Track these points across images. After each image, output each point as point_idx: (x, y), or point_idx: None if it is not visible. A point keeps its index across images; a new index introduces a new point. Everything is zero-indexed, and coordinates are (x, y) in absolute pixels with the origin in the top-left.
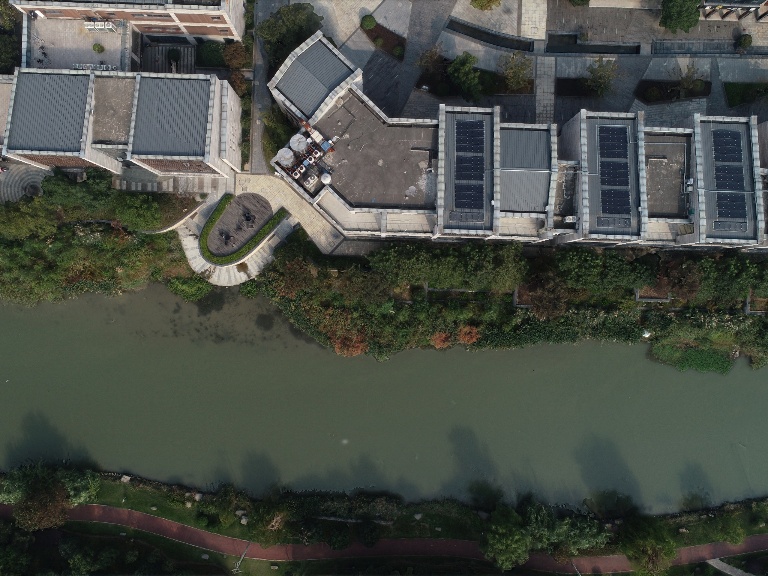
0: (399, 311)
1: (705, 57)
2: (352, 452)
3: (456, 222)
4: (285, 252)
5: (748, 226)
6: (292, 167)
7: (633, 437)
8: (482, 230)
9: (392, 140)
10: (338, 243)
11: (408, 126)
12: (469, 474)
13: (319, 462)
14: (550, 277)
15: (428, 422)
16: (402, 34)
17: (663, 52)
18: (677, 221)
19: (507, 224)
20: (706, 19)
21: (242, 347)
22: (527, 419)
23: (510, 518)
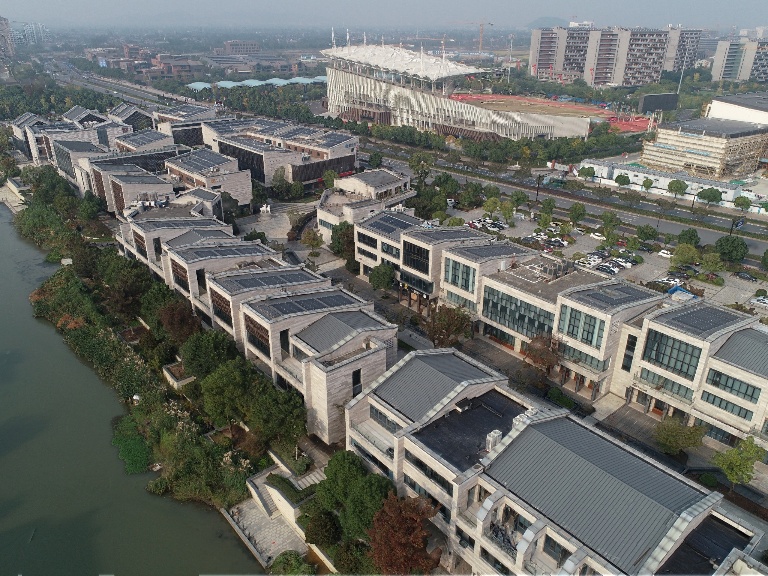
0: None
1: None
2: None
3: None
4: None
5: None
6: None
7: (10, 451)
8: (143, 229)
9: None
10: None
11: None
12: None
13: None
14: None
15: None
16: None
17: None
18: None
19: None
20: (409, 307)
21: (19, 279)
22: (6, 390)
23: None
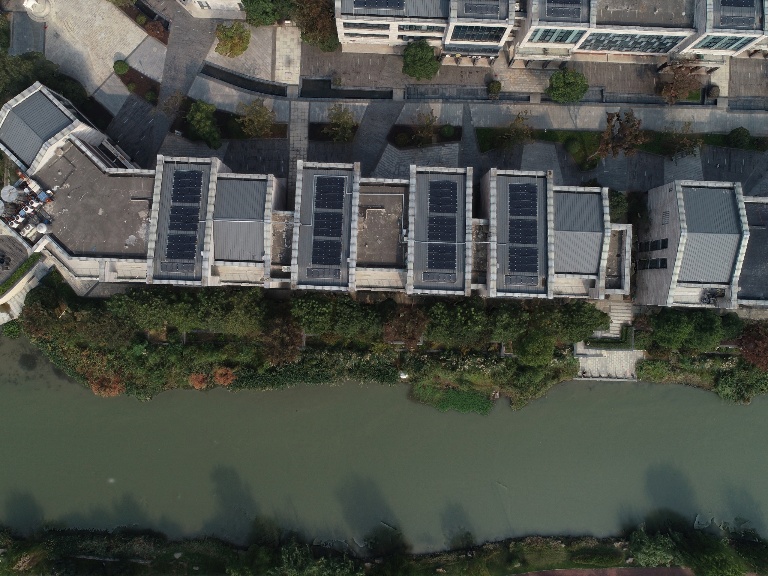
0: (151, 353)
1: (457, 102)
2: (115, 491)
3: (167, 272)
4: (31, 296)
5: (457, 277)
6: (11, 216)
7: (395, 477)
8: (191, 281)
9: (112, 190)
10: (93, 285)
11: (129, 176)
12: (231, 513)
13: (82, 501)
14: (280, 324)
15: (191, 461)
16: (157, 79)
17: (417, 97)
18: (393, 271)
19: (238, 271)
20: (458, 65)
21: (6, 387)
22: (290, 459)
23: (255, 559)
